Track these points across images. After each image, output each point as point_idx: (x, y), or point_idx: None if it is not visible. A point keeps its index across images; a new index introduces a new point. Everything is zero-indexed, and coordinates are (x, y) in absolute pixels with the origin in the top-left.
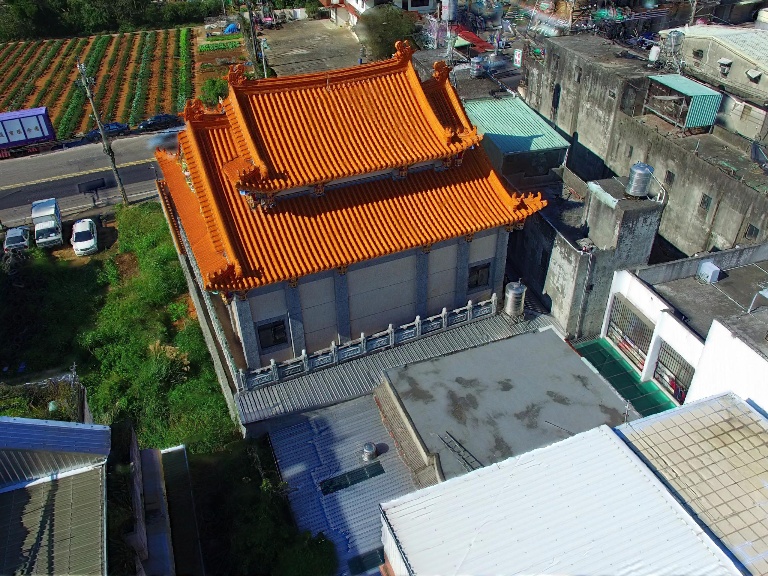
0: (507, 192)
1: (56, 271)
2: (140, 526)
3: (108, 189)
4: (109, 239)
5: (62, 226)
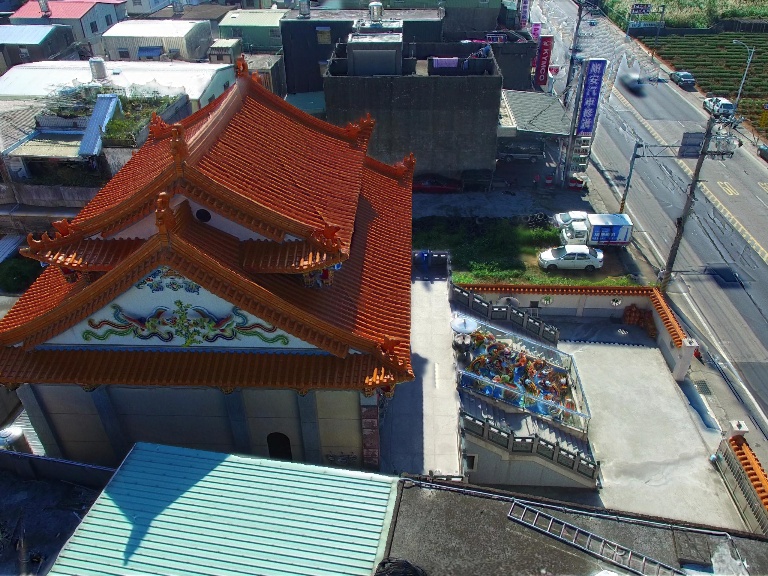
0: (25, 362)
1: (507, 242)
2: (73, 195)
3: (714, 282)
4: (573, 278)
5: (609, 248)
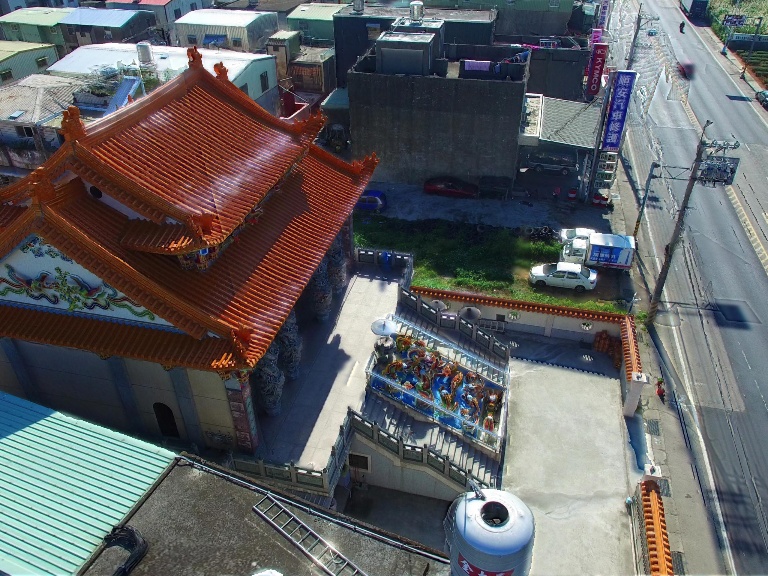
0: None
1: (503, 253)
2: None
3: None
4: (560, 296)
5: (609, 270)
